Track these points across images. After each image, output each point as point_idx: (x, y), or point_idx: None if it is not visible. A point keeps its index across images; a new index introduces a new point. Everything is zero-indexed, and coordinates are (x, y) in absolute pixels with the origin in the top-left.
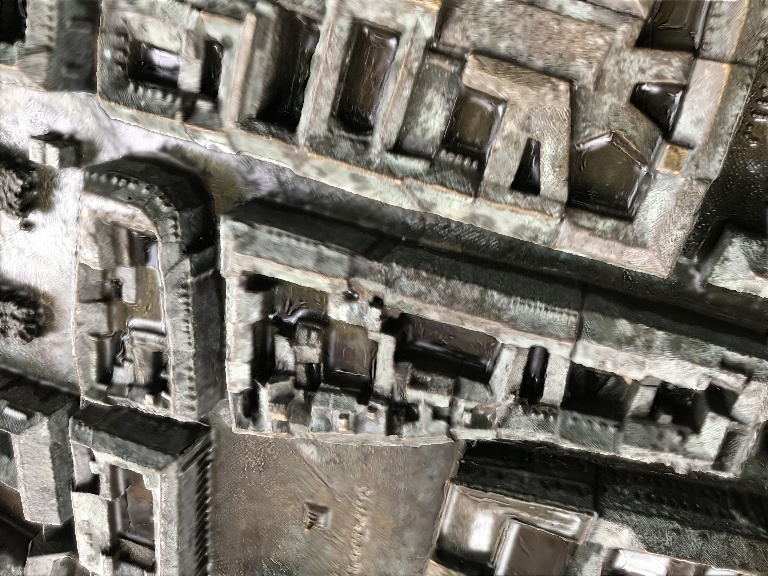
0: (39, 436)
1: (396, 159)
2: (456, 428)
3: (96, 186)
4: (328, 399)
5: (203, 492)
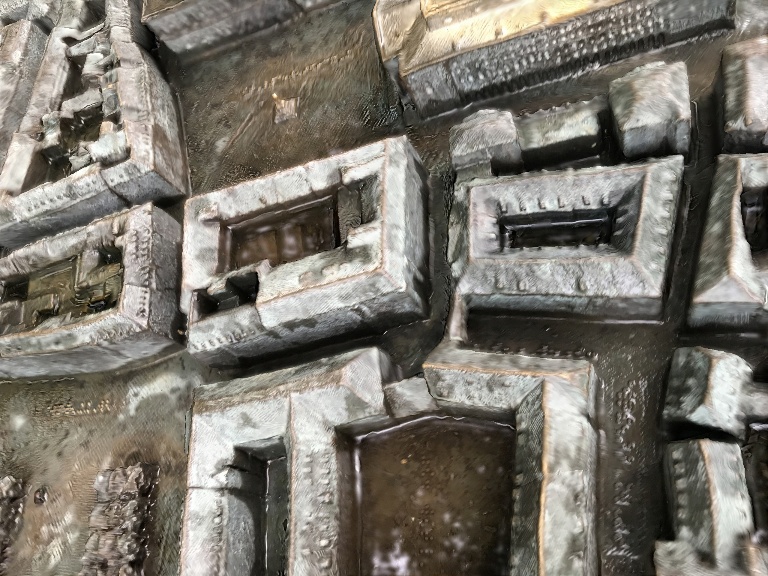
0: None
1: None
2: (112, 41)
3: None
4: None
5: None
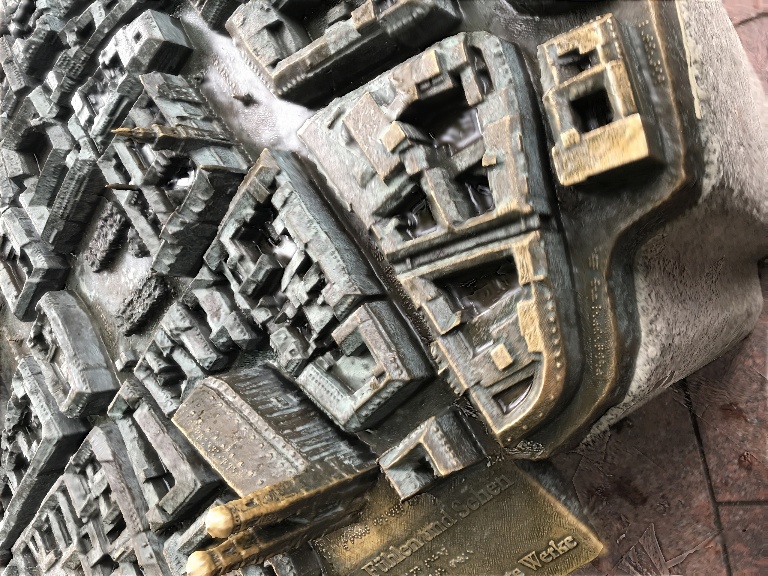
0: None
1: (46, 515)
2: (3, 452)
3: (79, 398)
4: (17, 415)
5: None
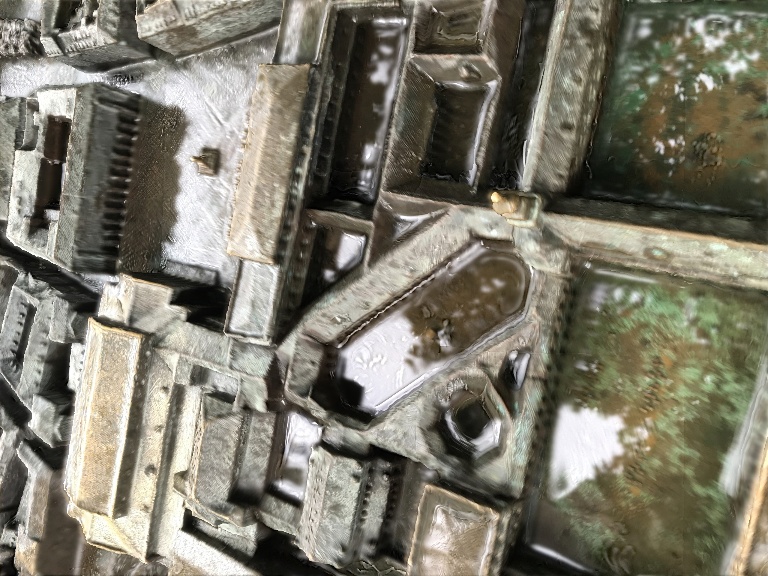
0: (10, 115)
1: None
2: None
3: None
4: None
5: (123, 163)
